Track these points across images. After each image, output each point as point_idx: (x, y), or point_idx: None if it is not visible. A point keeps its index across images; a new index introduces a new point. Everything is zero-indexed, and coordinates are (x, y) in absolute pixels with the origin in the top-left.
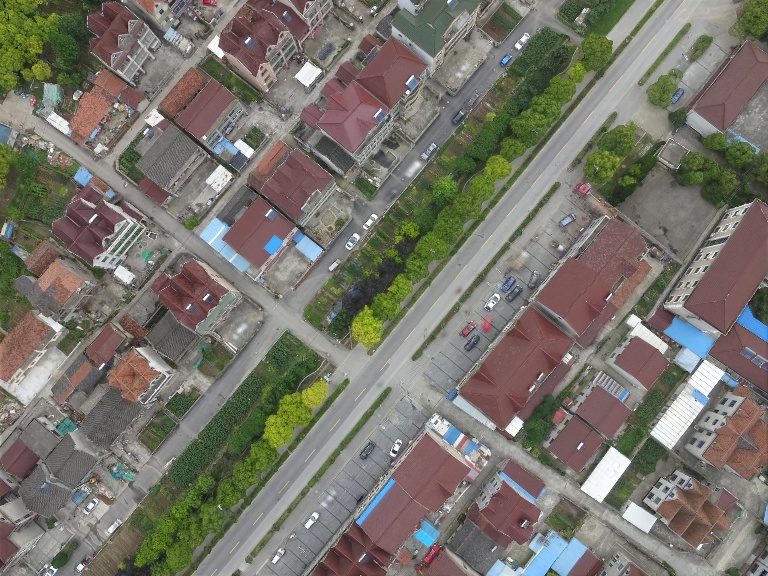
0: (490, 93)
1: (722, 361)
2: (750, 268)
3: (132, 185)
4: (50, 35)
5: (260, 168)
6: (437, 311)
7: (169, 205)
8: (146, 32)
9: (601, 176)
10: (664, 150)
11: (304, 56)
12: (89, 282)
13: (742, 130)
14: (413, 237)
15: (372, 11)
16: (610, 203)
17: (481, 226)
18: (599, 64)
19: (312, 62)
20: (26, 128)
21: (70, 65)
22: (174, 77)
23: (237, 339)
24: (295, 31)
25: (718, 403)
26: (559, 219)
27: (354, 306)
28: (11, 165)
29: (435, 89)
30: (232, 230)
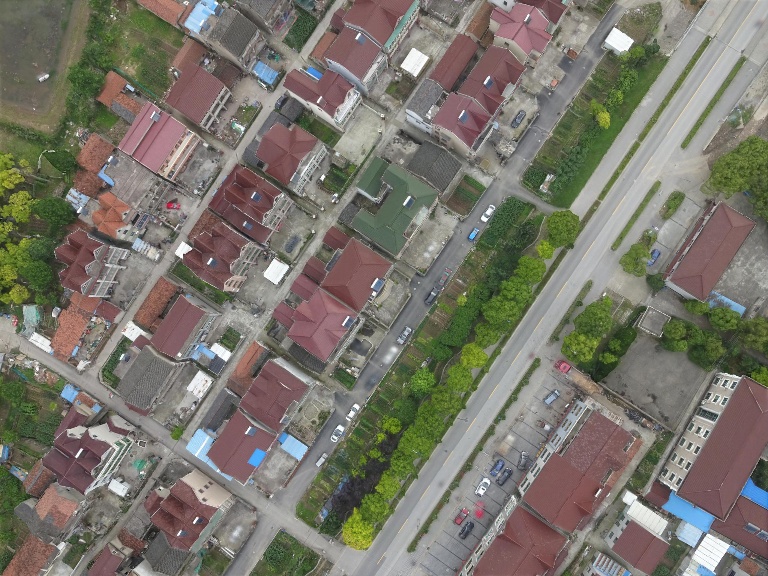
0: (461, 269)
1: (725, 535)
2: (743, 453)
3: (117, 395)
4: (21, 272)
5: (238, 372)
6: (428, 500)
7: (155, 412)
8: (113, 252)
9: (580, 359)
10: (644, 319)
11: (271, 251)
12: (85, 500)
13: (725, 286)
14: (395, 432)
15: (333, 201)
16: (593, 380)
17: (464, 410)
18: (567, 242)
19: (279, 259)
20: (11, 348)
21: (45, 286)
22: (147, 284)
23: (234, 541)
24: (257, 237)
25: (726, 575)
26: (543, 396)
27: (343, 507)
28: (1, 386)
29: (404, 271)
30: (215, 446)
